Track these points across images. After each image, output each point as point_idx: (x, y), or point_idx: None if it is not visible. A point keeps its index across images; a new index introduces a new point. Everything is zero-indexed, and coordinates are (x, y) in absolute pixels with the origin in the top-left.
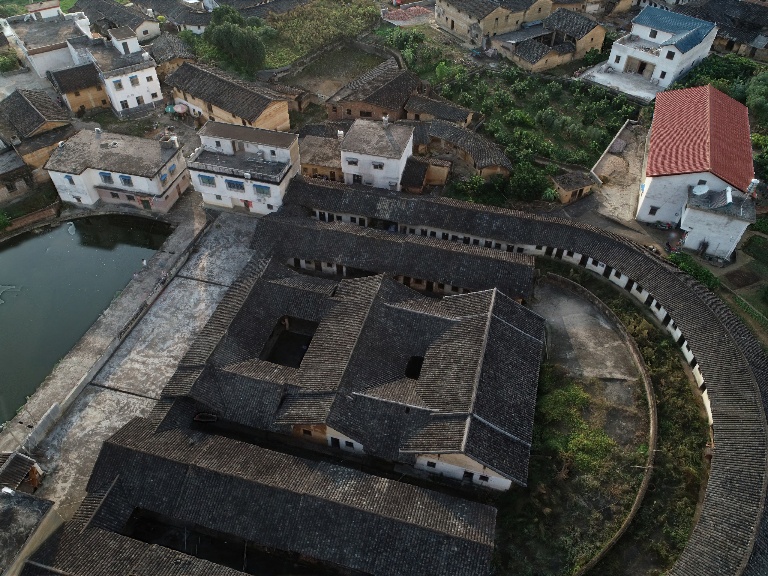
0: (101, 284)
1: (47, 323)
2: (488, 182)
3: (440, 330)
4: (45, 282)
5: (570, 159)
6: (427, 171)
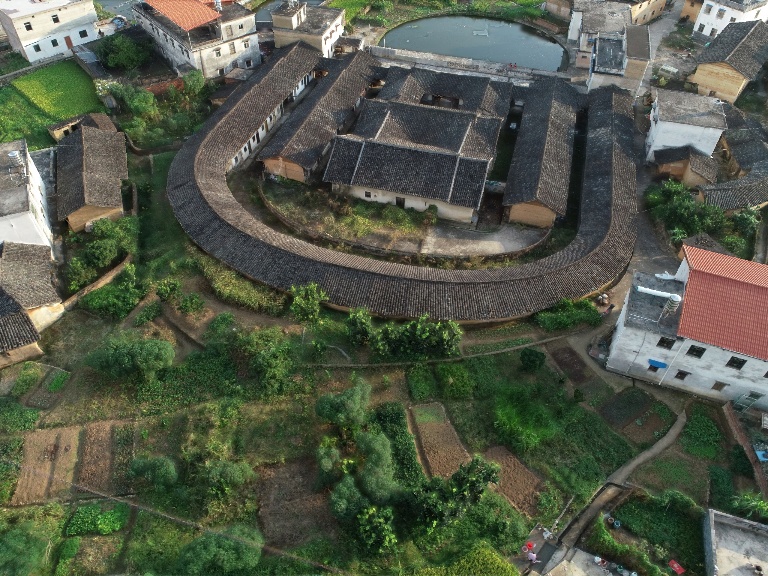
0: (497, 58)
1: (460, 47)
2: None
3: (451, 149)
4: (493, 42)
5: None
6: (686, 166)
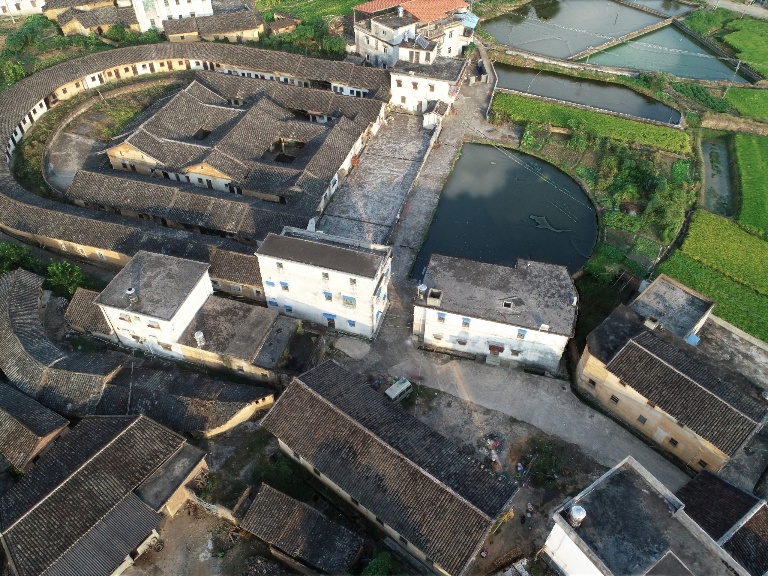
0: (457, 227)
1: (480, 199)
2: None
3: None
4: (507, 228)
5: None
6: None
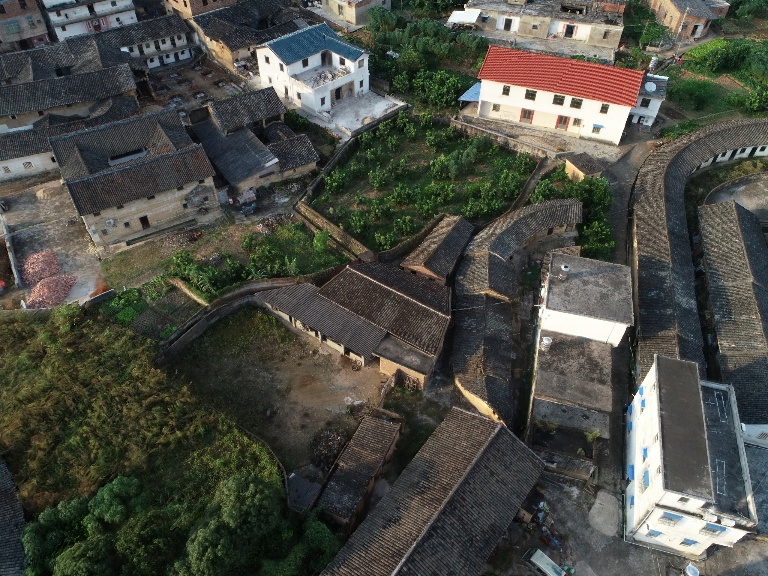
0: None
1: None
2: (575, 227)
3: None
4: None
5: (524, 166)
6: None
